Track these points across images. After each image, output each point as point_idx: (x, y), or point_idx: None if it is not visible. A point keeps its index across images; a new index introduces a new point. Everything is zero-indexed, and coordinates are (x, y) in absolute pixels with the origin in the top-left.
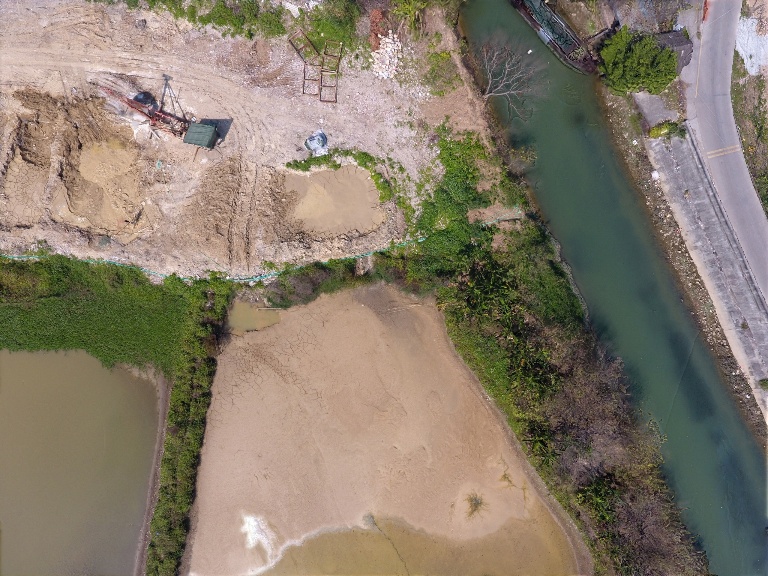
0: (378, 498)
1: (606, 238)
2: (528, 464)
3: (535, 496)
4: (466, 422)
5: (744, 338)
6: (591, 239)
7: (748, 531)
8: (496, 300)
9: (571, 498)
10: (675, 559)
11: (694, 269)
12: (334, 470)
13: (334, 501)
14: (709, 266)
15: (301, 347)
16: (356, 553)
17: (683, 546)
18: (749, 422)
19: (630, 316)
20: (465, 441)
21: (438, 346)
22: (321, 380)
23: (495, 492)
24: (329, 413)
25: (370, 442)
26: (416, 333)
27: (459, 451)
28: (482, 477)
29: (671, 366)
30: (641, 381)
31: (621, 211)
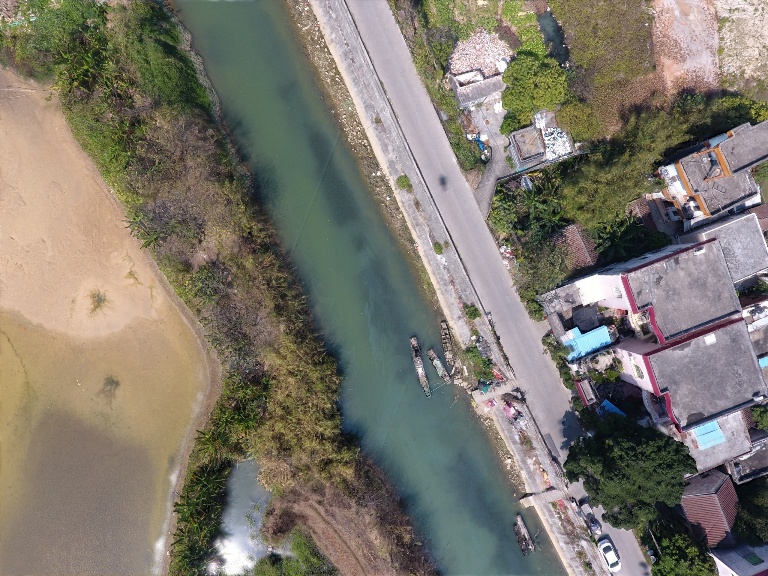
0: None
1: (248, 34)
2: (154, 261)
3: (163, 295)
4: (89, 215)
5: (379, 134)
6: (232, 34)
7: (391, 340)
8: (91, 72)
9: None
10: (279, 348)
11: (334, 65)
12: None
13: None
14: (344, 59)
15: None
16: None
17: (290, 336)
18: (391, 226)
19: (267, 112)
20: (88, 235)
21: (60, 135)
22: None
23: (120, 289)
24: None
25: None
26: (36, 121)
27: (81, 245)
28: (106, 273)
29: (311, 166)
30: (276, 179)
31: (261, 5)
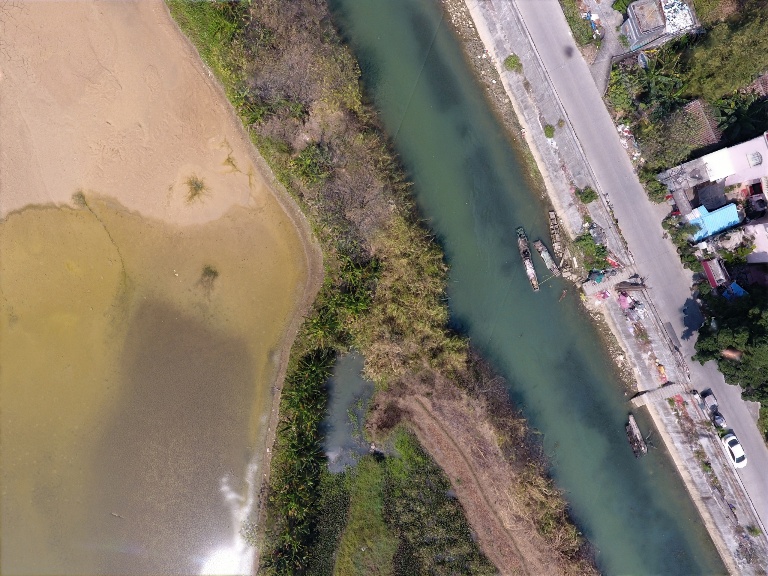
0: (89, 176)
1: None
2: (253, 147)
3: (262, 183)
4: (187, 100)
5: (486, 13)
6: None
7: (496, 231)
8: None
9: (293, 178)
10: (390, 228)
11: None
12: (41, 144)
13: (41, 177)
14: None
15: (6, 10)
16: (64, 234)
17: (400, 216)
18: (497, 111)
19: None
20: (185, 120)
21: (157, 17)
22: (28, 46)
23: (218, 177)
24: (36, 82)
25: (81, 116)
26: (133, 2)
27: (178, 130)
28: (203, 160)
29: (413, 50)
30: (378, 62)
31: None
